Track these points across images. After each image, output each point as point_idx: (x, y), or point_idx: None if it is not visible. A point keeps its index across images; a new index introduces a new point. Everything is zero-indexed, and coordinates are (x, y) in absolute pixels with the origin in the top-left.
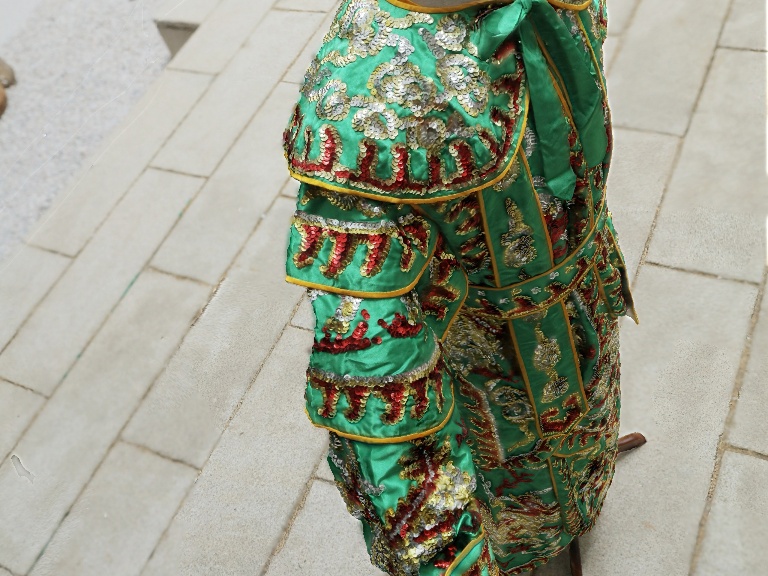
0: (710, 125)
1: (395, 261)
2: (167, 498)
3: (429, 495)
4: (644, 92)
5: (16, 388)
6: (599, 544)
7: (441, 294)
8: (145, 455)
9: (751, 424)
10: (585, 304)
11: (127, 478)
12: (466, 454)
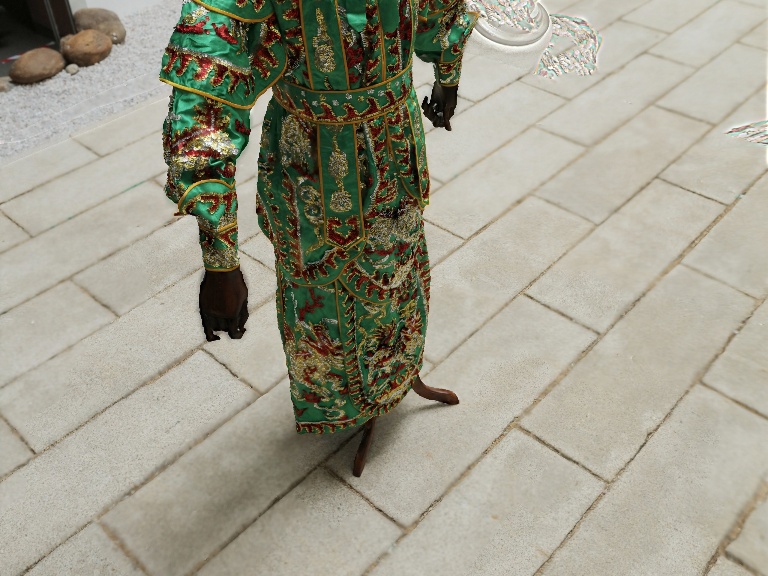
0: (622, 224)
1: None
2: (84, 326)
3: (204, 135)
4: (585, 188)
5: (12, 223)
6: (387, 455)
7: (266, 56)
8: (83, 295)
9: (542, 417)
10: (371, 138)
11: (62, 304)
12: (239, 138)
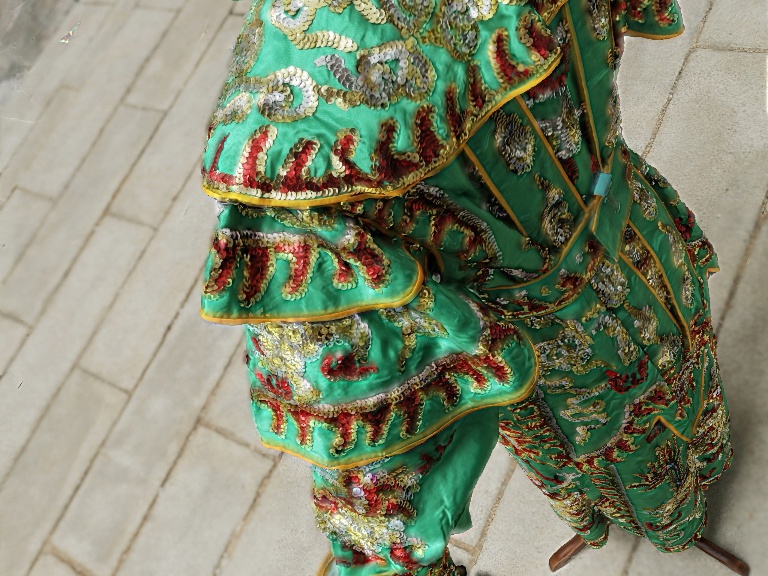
0: None
1: None
2: None
3: None
4: None
5: None
6: None
7: None
8: None
9: None
10: None
11: None
12: None
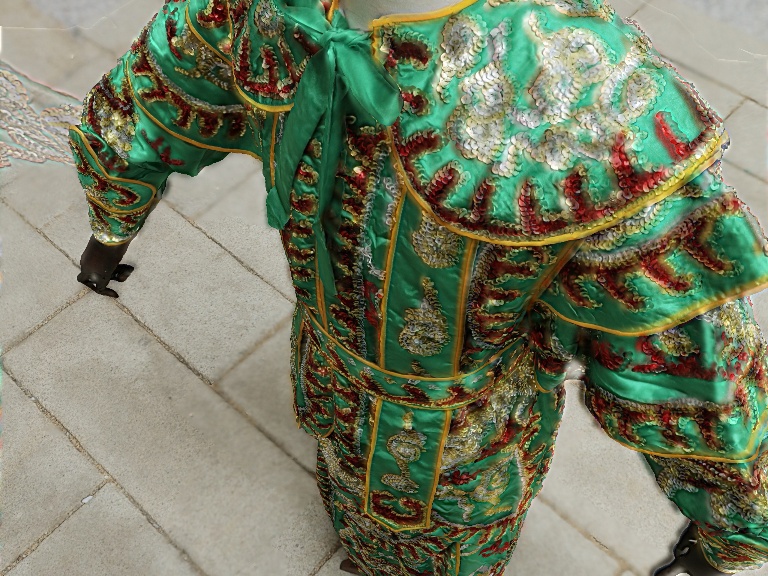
0: None
1: (201, 3)
2: None
3: None
4: None
5: None
6: None
7: None
8: None
9: None
10: None
11: None
12: (144, 150)
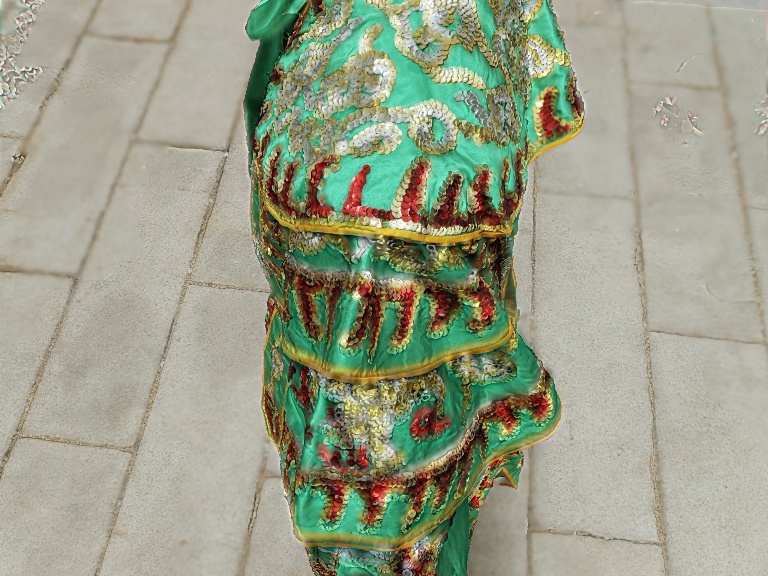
0: None
1: None
2: None
3: None
4: None
5: None
6: None
7: None
8: None
9: None
10: None
11: None
12: None
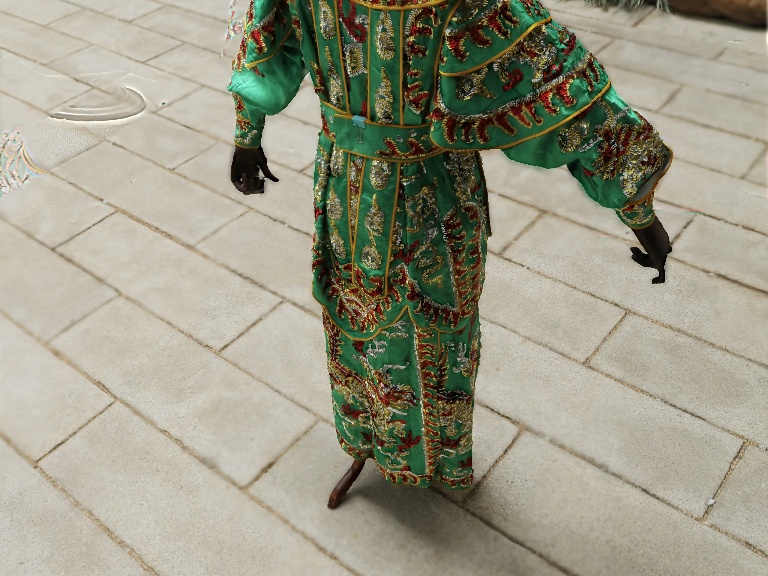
0: (125, 277)
1: None
2: None
3: None
4: (52, 300)
5: None
6: None
7: None
8: None
9: None
10: None
11: None
12: None
